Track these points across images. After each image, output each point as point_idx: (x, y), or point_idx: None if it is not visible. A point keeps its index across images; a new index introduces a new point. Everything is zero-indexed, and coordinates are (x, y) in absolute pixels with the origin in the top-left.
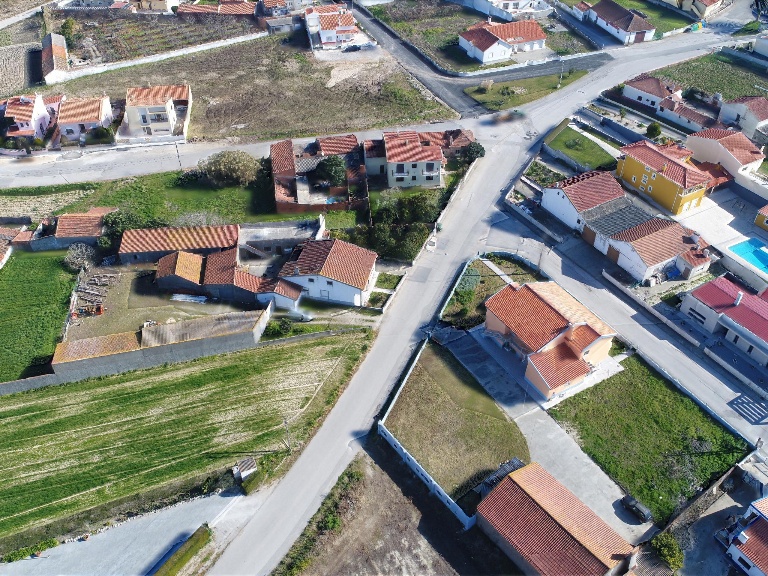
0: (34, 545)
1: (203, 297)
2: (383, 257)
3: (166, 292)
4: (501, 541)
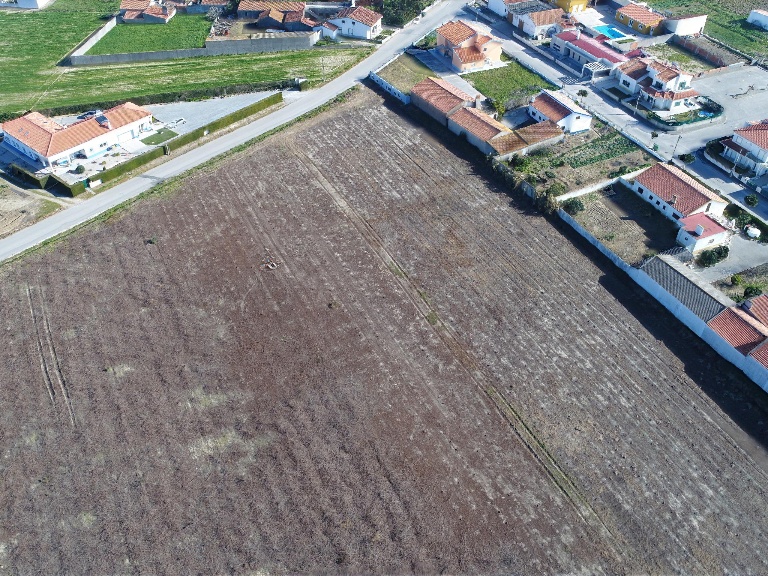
0: (201, 97)
1: (283, 30)
2: (387, 23)
3: (263, 28)
4: (420, 102)
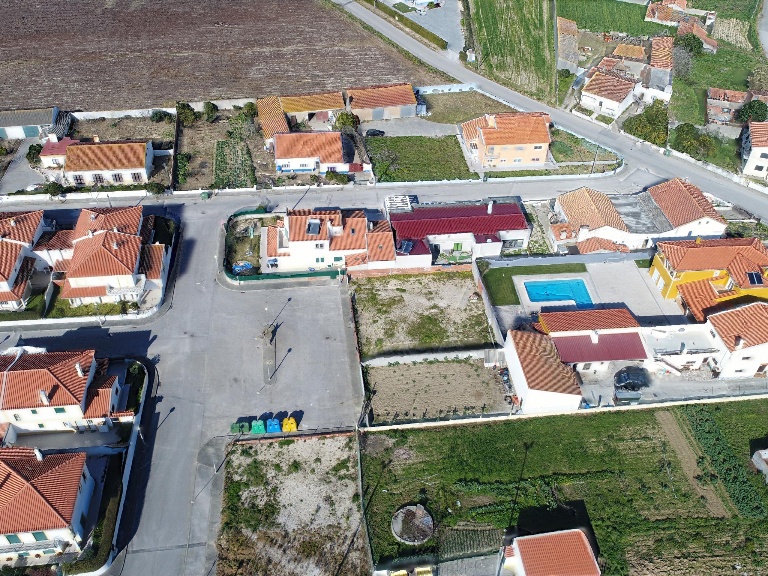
0: None
1: None
2: None
3: None
4: None
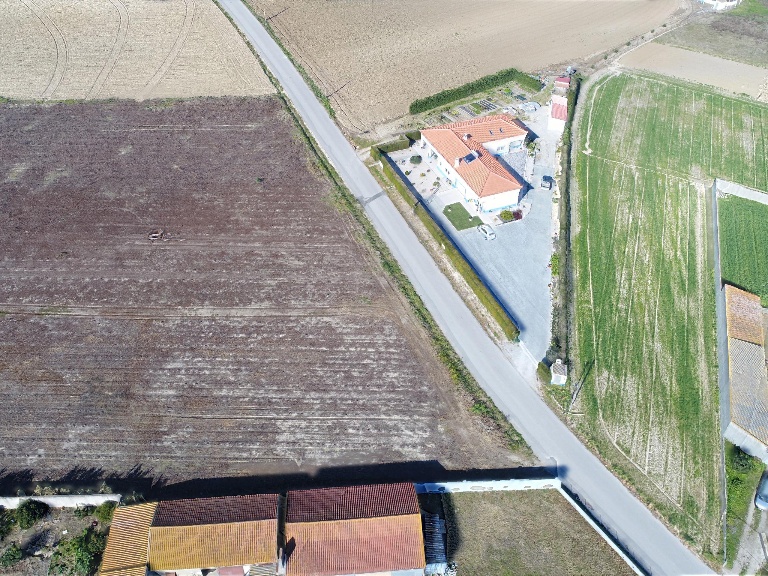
0: None
1: None
2: None
3: None
4: None
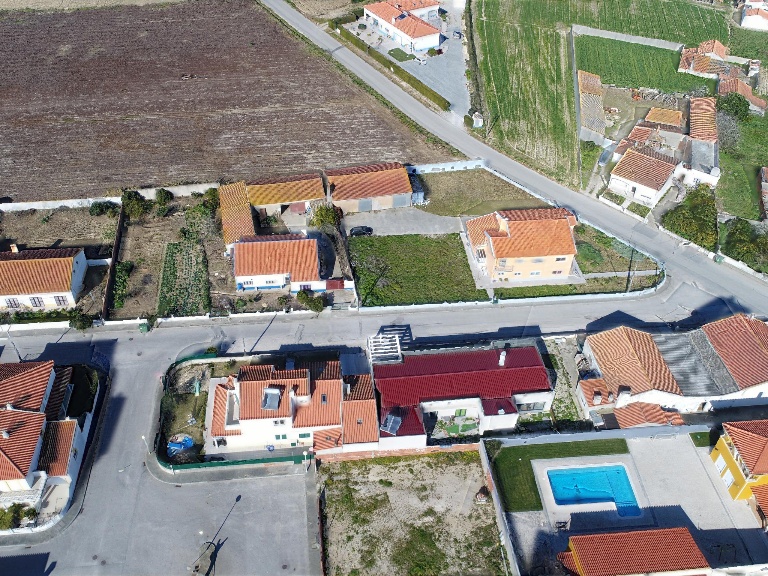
0: None
1: None
2: None
3: None
4: None
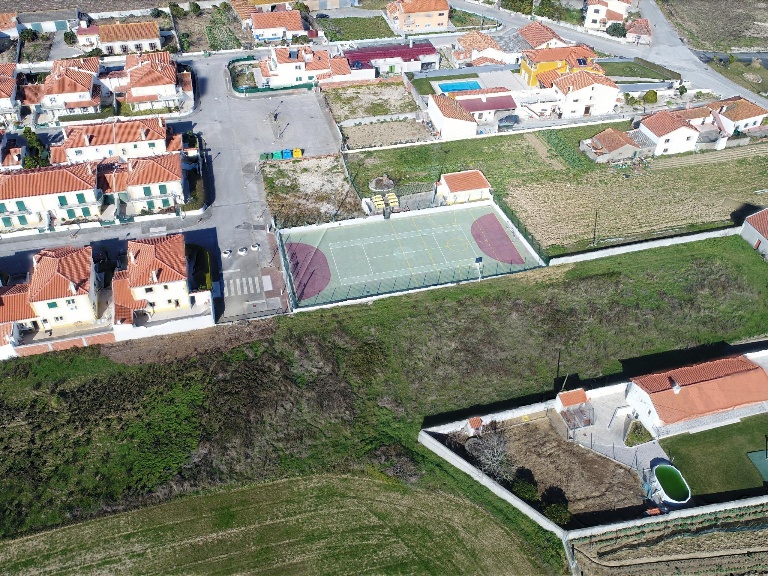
0: None
1: None
2: None
3: None
4: None
